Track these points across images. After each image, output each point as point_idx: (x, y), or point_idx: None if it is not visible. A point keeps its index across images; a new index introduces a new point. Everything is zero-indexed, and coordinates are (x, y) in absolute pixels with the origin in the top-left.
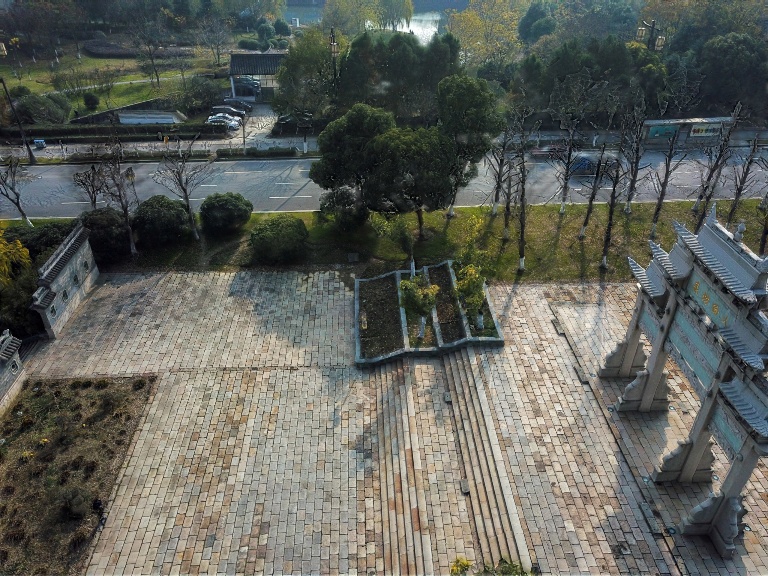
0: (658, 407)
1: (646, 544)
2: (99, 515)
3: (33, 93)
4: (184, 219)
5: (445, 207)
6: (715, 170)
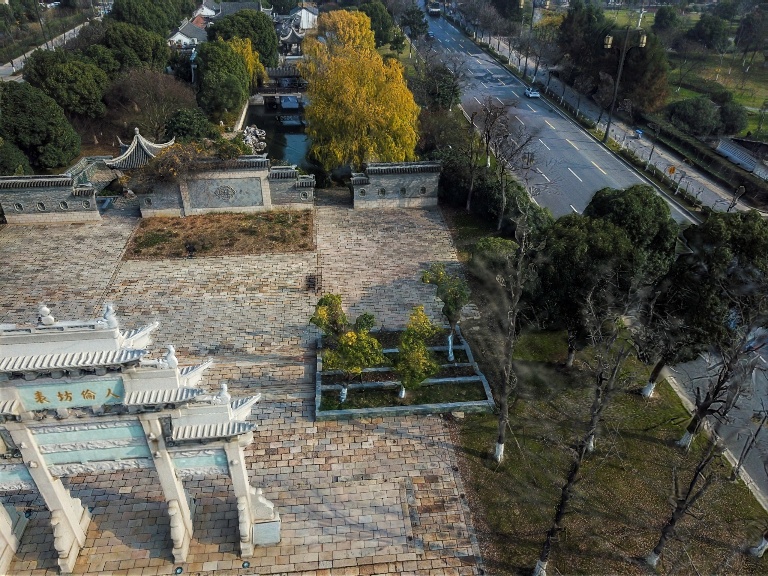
0: None
1: (28, 493)
2: (195, 256)
3: (730, 102)
4: (498, 206)
5: (574, 346)
6: None
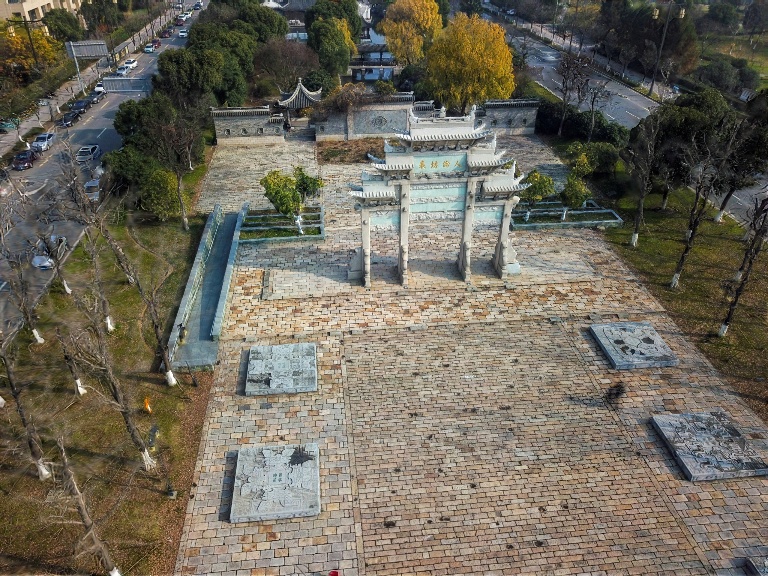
0: None
1: None
2: None
3: (747, 67)
4: (588, 128)
5: (672, 187)
6: None
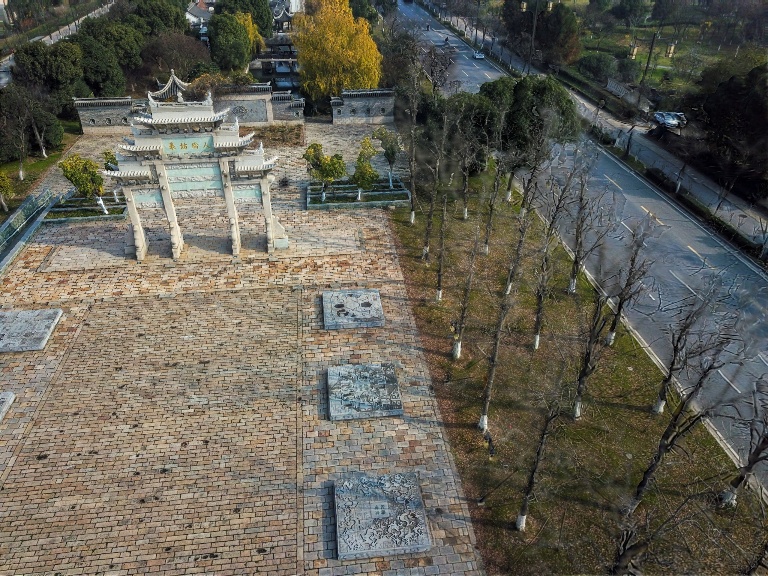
0: None
1: None
2: None
3: None
4: None
5: None
6: (626, 300)
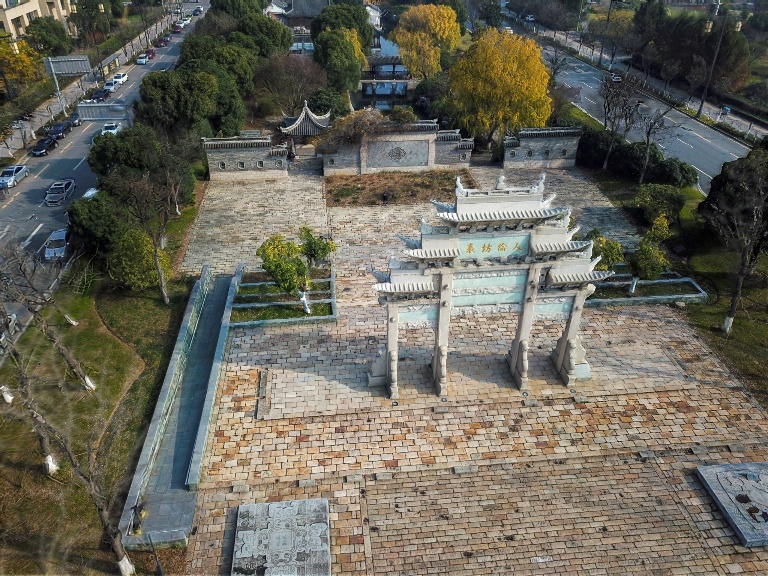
0: (517, 379)
1: None
2: None
3: None
4: (641, 162)
5: (767, 252)
6: None
